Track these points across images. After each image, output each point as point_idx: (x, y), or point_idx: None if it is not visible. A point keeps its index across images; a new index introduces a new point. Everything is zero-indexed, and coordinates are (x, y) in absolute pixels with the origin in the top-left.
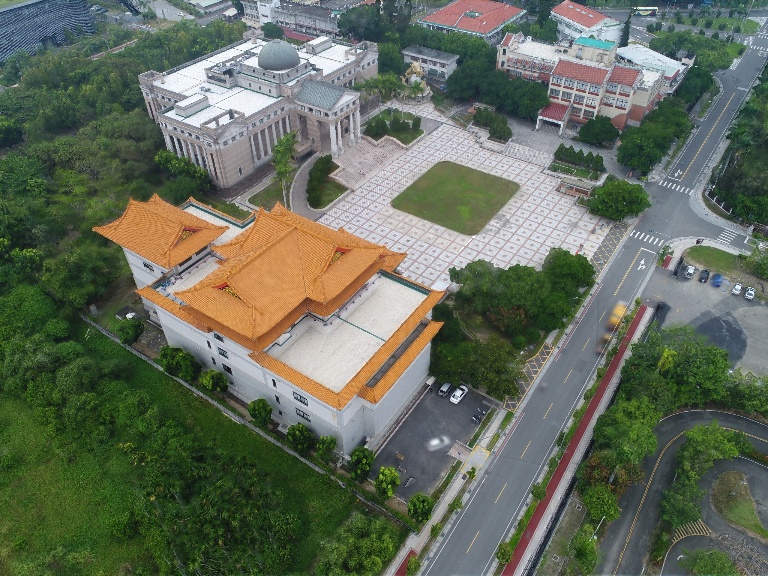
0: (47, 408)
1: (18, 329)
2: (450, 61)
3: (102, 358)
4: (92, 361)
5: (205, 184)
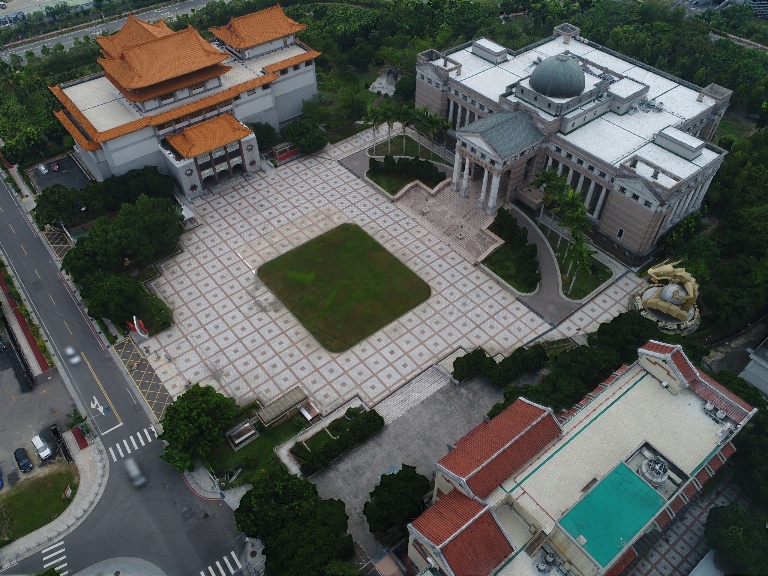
0: None
1: None
2: (759, 358)
3: None
4: None
5: None
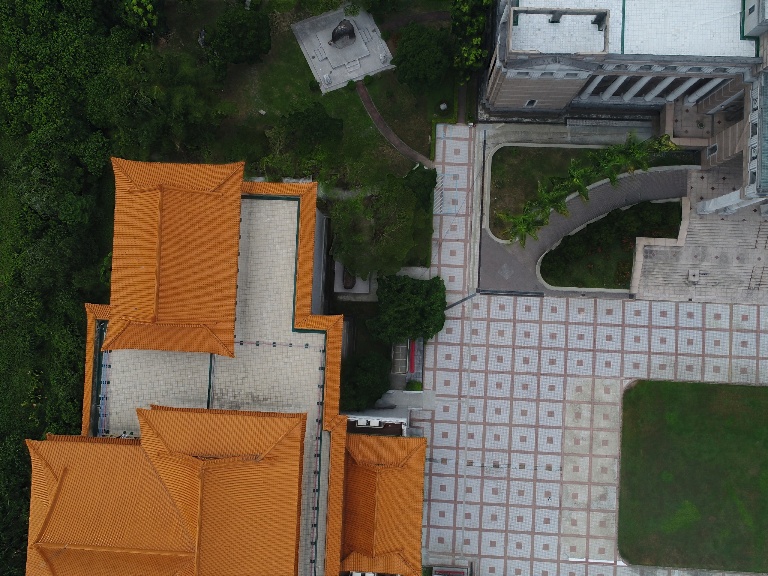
0: (16, 255)
1: None
2: None
3: None
4: (62, 268)
5: (465, 72)
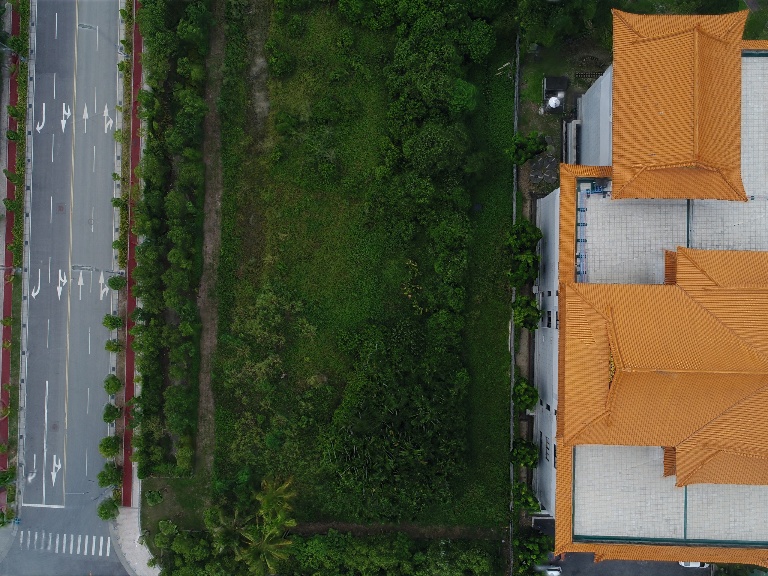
0: (393, 146)
1: (447, 6)
2: None
3: (486, 120)
4: (463, 150)
5: None
